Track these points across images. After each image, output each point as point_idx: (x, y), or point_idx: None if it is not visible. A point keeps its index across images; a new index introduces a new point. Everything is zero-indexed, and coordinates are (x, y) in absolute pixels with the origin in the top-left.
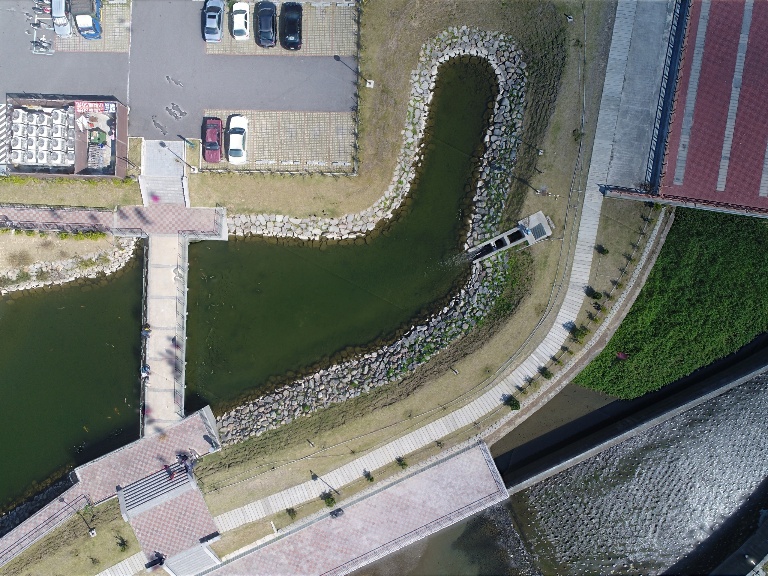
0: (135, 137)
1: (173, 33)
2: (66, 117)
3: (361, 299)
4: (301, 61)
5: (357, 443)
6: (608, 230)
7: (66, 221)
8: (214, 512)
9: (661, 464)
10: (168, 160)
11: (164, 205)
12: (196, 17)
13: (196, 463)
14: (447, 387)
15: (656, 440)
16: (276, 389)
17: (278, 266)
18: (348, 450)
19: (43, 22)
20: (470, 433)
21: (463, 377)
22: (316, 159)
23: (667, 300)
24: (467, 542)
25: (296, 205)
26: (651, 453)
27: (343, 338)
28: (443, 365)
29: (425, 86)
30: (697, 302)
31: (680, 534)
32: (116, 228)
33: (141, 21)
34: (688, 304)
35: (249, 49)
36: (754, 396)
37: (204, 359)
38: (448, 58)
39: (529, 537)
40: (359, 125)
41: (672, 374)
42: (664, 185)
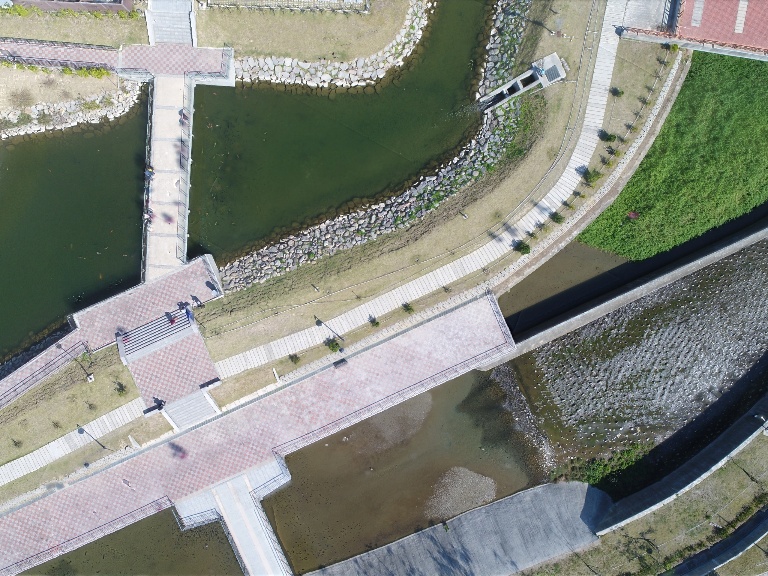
0: None
1: None
2: None
3: (369, 150)
4: None
5: (363, 288)
6: (623, 73)
7: (70, 59)
8: (215, 357)
9: (671, 325)
10: None
11: (170, 45)
12: None
13: (198, 309)
14: (456, 232)
15: (666, 300)
16: (281, 239)
17: (285, 115)
18: (354, 295)
19: None
20: (478, 279)
21: (472, 222)
22: None
23: (680, 157)
24: (472, 405)
25: (306, 47)
26: (661, 314)
27: (350, 190)
28: (452, 210)
29: None
30: (711, 158)
31: (688, 397)
32: (121, 68)
33: None
34: (702, 161)
35: None
36: (766, 256)
37: (208, 210)
38: None
39: (535, 400)
40: None
41: (684, 234)
42: (681, 26)
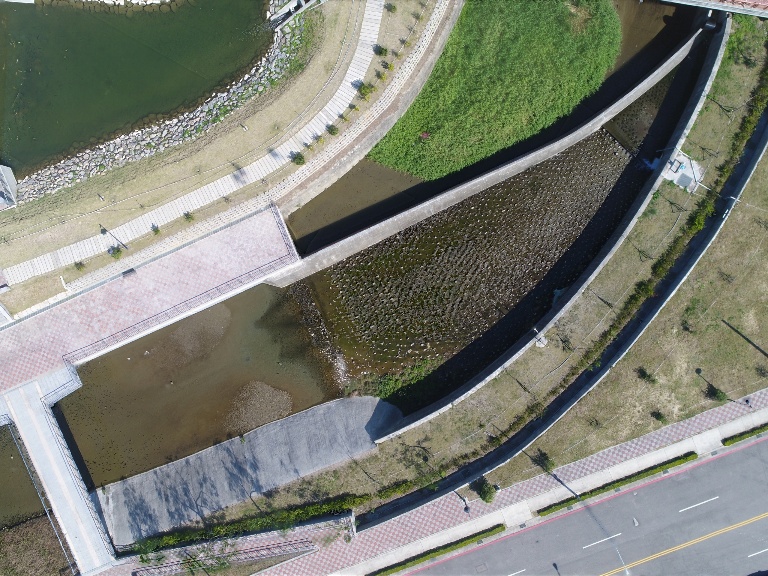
0: None
1: None
2: None
3: (166, 68)
4: None
5: (146, 198)
6: None
7: None
8: (4, 264)
9: (459, 243)
10: None
11: None
12: None
13: None
14: (236, 143)
15: (455, 219)
16: (77, 153)
17: (85, 33)
18: (137, 204)
19: None
20: (258, 190)
21: (252, 133)
22: None
23: (469, 78)
24: (270, 321)
25: None
26: (450, 232)
27: (147, 107)
28: (234, 123)
29: None
30: (497, 79)
31: (476, 313)
32: None
33: None
34: (488, 81)
35: None
36: (551, 176)
37: (10, 125)
38: None
39: (330, 316)
40: None
41: (473, 154)
42: None
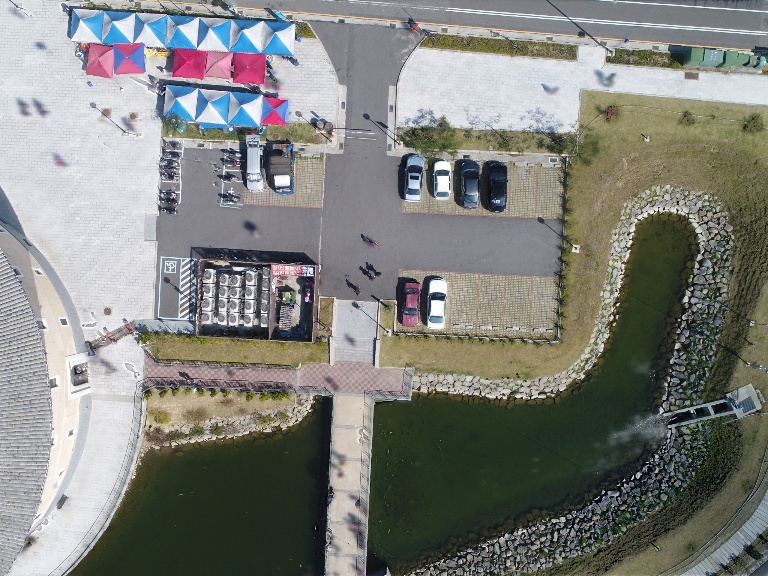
0: (327, 297)
1: (368, 189)
2: (256, 276)
3: (547, 459)
4: (503, 223)
5: None
6: None
7: (248, 379)
8: None
9: None
10: (360, 321)
11: (350, 363)
12: (393, 173)
13: None
14: (648, 563)
15: None
16: (459, 552)
17: (461, 423)
18: None
19: (231, 174)
20: None
21: (665, 553)
22: (516, 324)
23: None
24: None
25: (489, 367)
26: None
27: (527, 499)
28: (643, 539)
29: (623, 244)
30: None
31: None
32: (299, 386)
33: (335, 176)
34: None
35: (448, 208)
36: None
37: (381, 517)
38: (647, 215)
39: None
40: (564, 291)
41: None
42: None
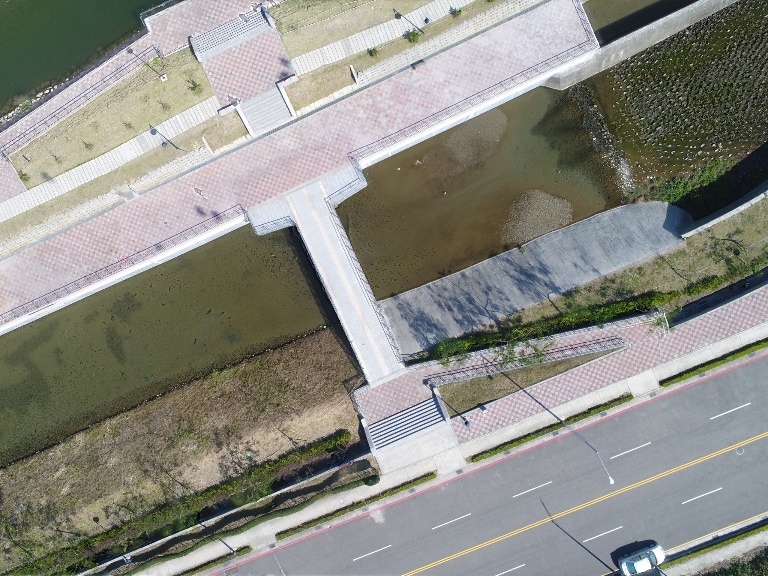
0: None
1: None
2: None
3: None
4: None
5: None
6: None
7: None
8: (292, 53)
9: (754, 36)
10: None
11: None
12: None
13: (273, 9)
14: None
15: (749, 11)
16: None
17: None
18: None
19: None
20: None
21: None
22: None
23: None
24: (548, 126)
25: None
26: (744, 25)
27: None
28: None
29: None
30: None
31: None
32: None
33: None
34: None
35: None
36: None
37: None
38: None
39: (613, 119)
40: None
41: None
42: None
